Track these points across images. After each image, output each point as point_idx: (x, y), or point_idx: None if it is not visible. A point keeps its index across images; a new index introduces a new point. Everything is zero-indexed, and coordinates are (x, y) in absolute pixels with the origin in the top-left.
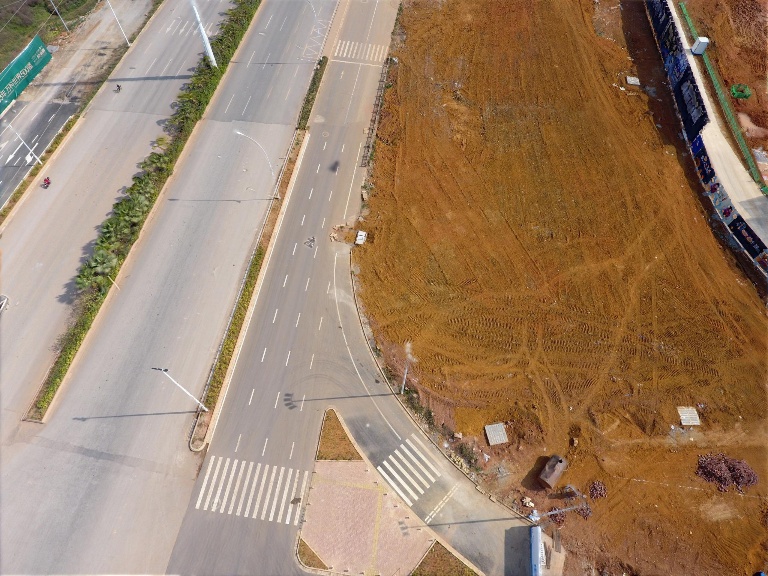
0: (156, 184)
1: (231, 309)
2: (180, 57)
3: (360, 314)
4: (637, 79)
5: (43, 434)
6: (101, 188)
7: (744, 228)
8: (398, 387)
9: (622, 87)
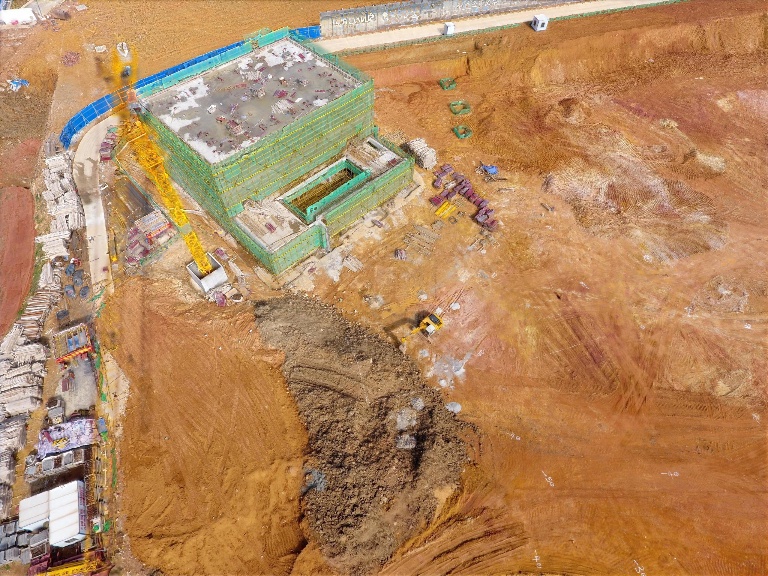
0: None
1: None
2: None
3: None
4: None
5: None
6: None
7: None
8: None
9: None
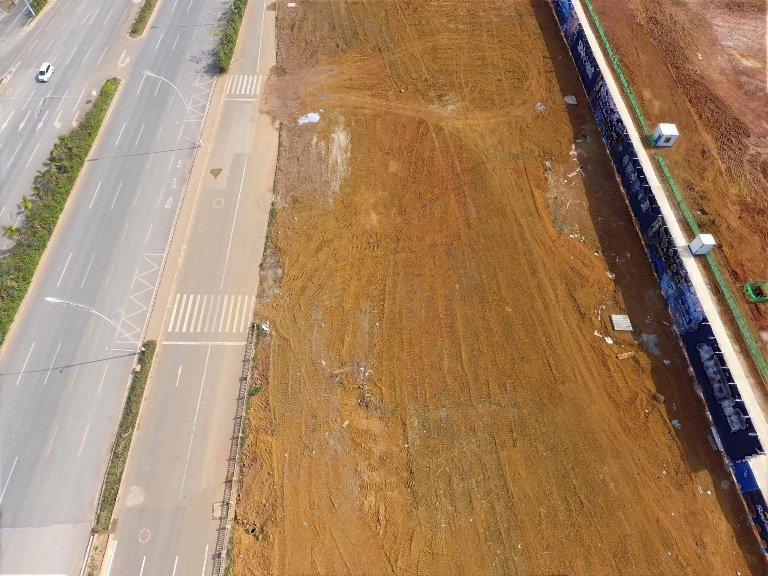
0: None
1: None
2: None
3: None
4: (627, 319)
5: None
6: None
7: None
8: None
9: (608, 337)
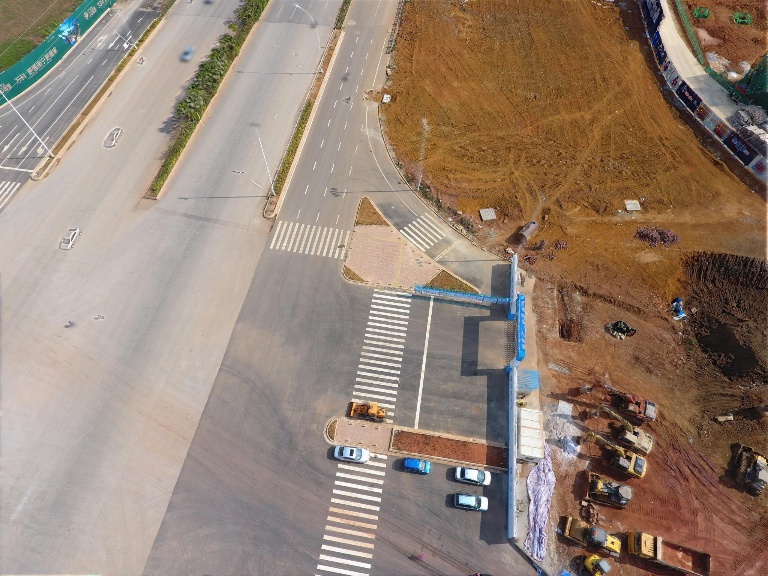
0: (228, 59)
1: (289, 139)
2: None
3: (386, 144)
4: None
5: (158, 206)
6: (185, 61)
7: (686, 90)
8: (415, 186)
9: (599, 3)
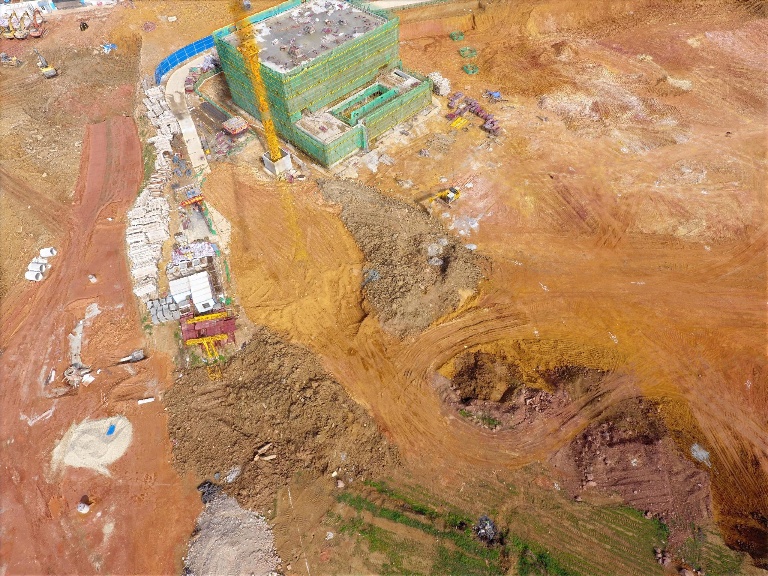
0: None
1: None
2: None
3: None
4: None
5: None
6: None
7: None
8: None
9: None
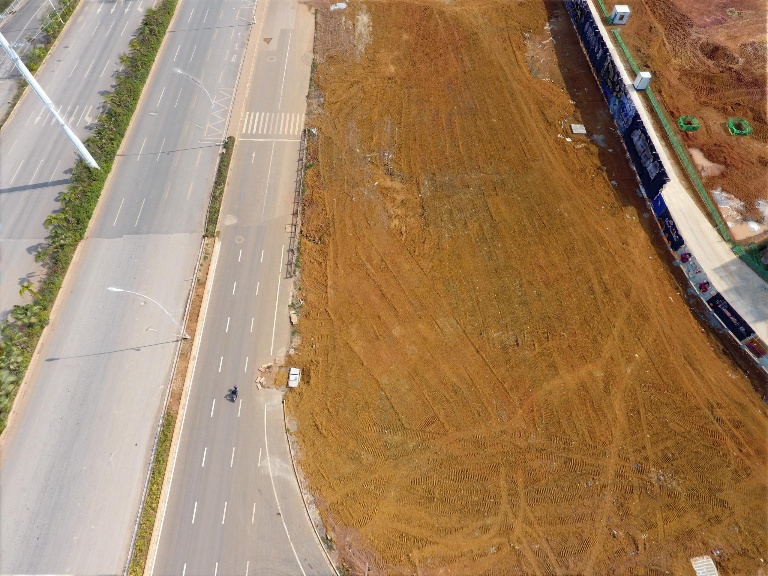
0: (26, 345)
1: (136, 512)
2: (53, 156)
3: (302, 490)
4: (583, 127)
5: None
6: None
7: (726, 307)
8: None
9: (568, 138)
